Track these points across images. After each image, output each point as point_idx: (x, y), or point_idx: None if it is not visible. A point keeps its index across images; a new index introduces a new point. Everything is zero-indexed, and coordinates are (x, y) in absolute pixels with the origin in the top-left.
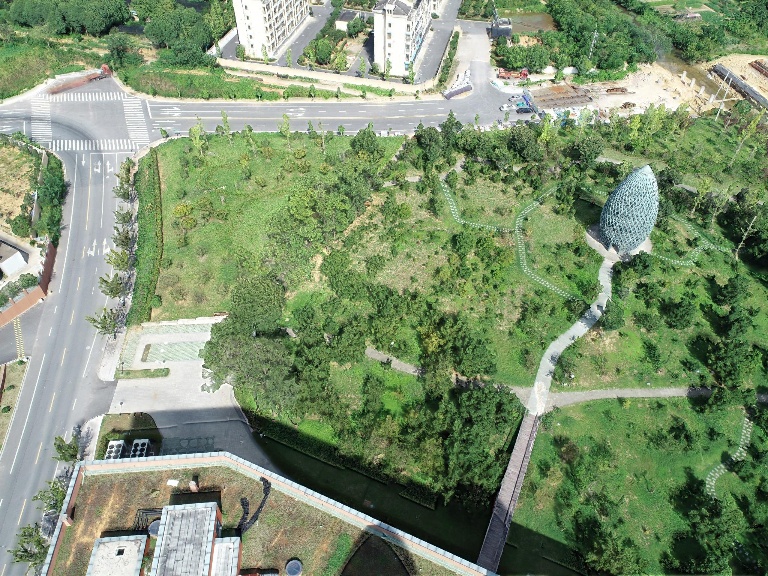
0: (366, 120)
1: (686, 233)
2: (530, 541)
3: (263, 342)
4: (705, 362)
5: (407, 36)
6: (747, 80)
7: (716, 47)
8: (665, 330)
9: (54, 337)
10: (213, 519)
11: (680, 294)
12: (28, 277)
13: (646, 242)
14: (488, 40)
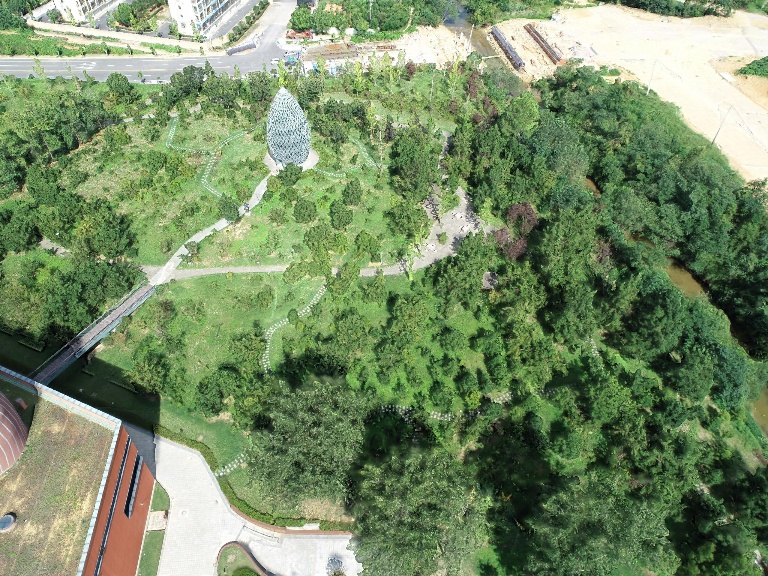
0: (146, 72)
1: None
2: (105, 371)
3: None
4: None
5: None
6: (515, 40)
7: (498, 12)
8: (293, 224)
9: None
10: None
11: (319, 197)
12: None
13: (314, 160)
14: (295, 7)
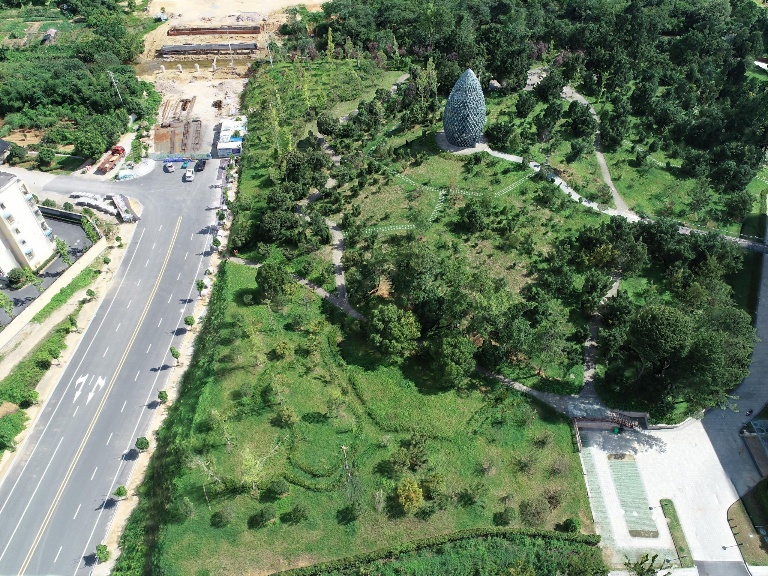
0: (157, 301)
1: None
2: None
3: (731, 311)
4: (576, 137)
5: (29, 202)
6: (194, 44)
7: None
8: None
9: None
10: None
11: (518, 129)
12: None
13: None
14: None
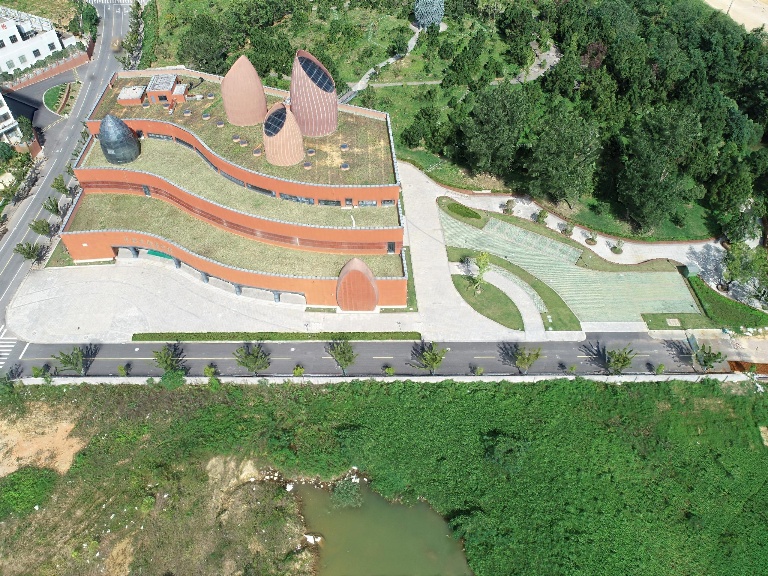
0: None
1: None
2: None
3: (205, 35)
4: None
5: None
6: None
7: None
8: (439, 60)
9: (96, 75)
10: (175, 77)
11: None
12: (81, 44)
13: (444, 27)
14: None
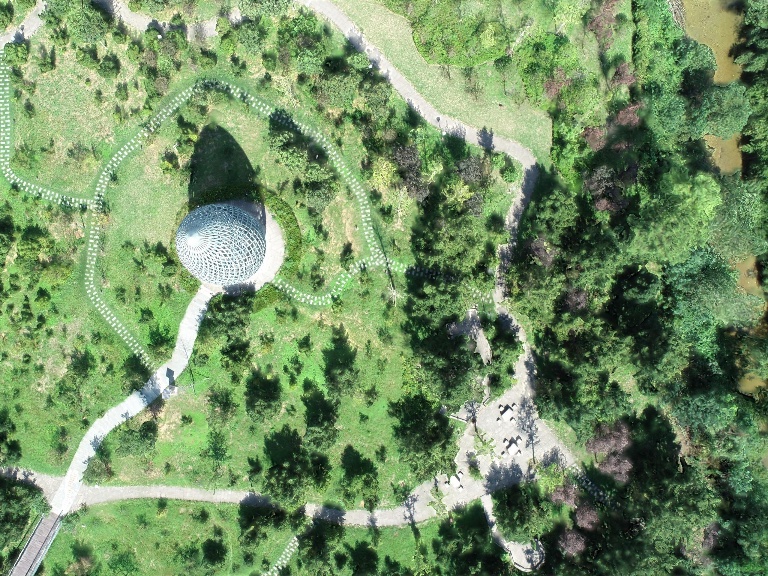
0: None
1: (352, 229)
2: None
3: None
4: None
5: None
6: None
7: None
8: None
9: None
10: None
11: (286, 359)
12: None
13: (276, 253)
14: None
